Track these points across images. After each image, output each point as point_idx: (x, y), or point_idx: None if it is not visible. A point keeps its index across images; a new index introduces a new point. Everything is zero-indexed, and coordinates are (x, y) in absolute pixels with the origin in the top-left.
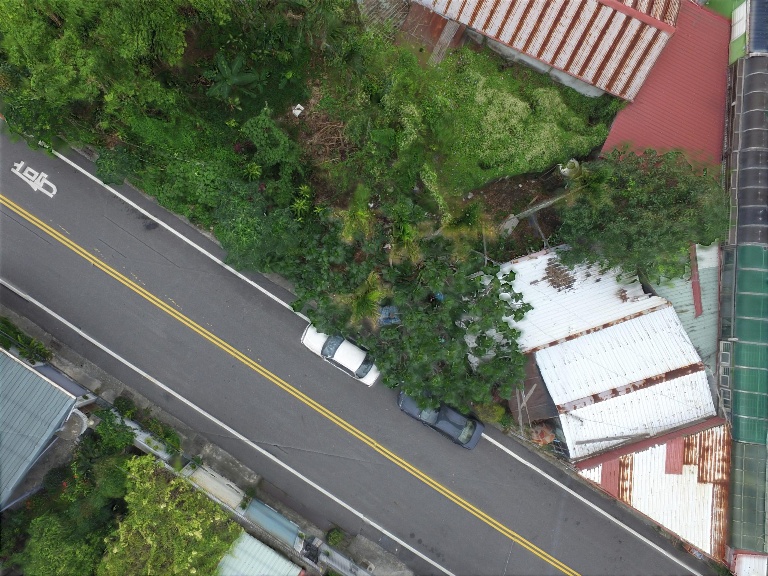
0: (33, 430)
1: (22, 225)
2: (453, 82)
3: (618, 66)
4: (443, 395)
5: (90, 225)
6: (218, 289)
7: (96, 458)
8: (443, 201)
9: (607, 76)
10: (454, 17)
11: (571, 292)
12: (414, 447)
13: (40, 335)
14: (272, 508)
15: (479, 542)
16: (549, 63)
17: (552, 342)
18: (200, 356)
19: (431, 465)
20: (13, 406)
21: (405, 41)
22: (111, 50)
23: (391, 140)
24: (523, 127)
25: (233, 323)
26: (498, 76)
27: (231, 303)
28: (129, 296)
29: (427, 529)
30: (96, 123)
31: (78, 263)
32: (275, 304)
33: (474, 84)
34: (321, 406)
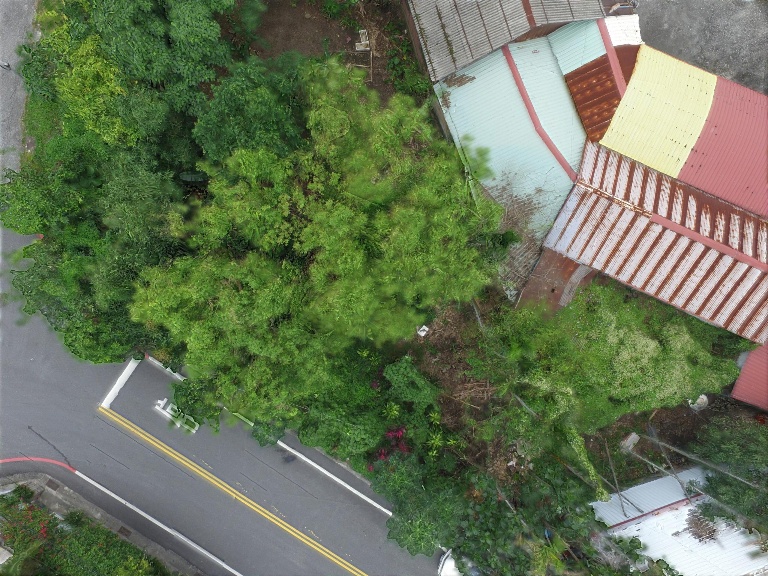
0: None
1: (167, 461)
2: (585, 323)
3: (750, 313)
4: None
5: (231, 459)
6: (355, 519)
7: None
8: (594, 470)
9: (739, 321)
10: (587, 263)
11: (711, 542)
12: None
13: (185, 567)
14: None
15: None
16: (681, 307)
17: None
18: None
19: None
20: None
21: (538, 283)
22: (296, 369)
23: None
24: (654, 366)
25: (370, 553)
26: (624, 308)
27: (368, 533)
28: (270, 529)
29: None
30: None
31: (221, 497)
32: None
33: (606, 326)
34: None
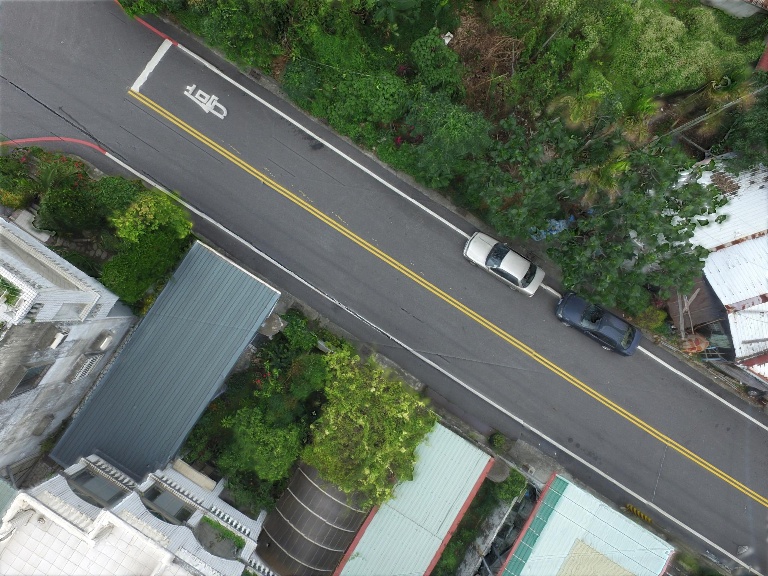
0: (242, 323)
1: (196, 145)
2: None
3: None
4: (628, 289)
5: (259, 145)
6: (381, 206)
7: (285, 358)
8: (622, 107)
9: None
10: None
11: (736, 198)
12: (571, 356)
13: None
14: (437, 414)
15: (634, 446)
16: None
17: (719, 246)
18: (366, 270)
19: (587, 373)
20: (223, 300)
21: None
22: None
23: (568, 51)
24: (679, 45)
25: (396, 238)
26: None
27: (394, 219)
28: (298, 213)
29: (585, 434)
30: (280, 40)
31: (249, 181)
32: (435, 221)
33: (632, 4)
34: (481, 317)
